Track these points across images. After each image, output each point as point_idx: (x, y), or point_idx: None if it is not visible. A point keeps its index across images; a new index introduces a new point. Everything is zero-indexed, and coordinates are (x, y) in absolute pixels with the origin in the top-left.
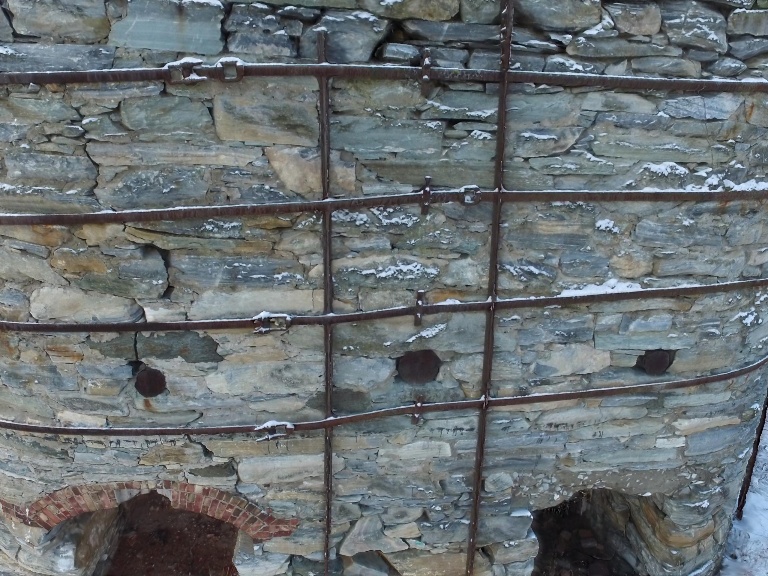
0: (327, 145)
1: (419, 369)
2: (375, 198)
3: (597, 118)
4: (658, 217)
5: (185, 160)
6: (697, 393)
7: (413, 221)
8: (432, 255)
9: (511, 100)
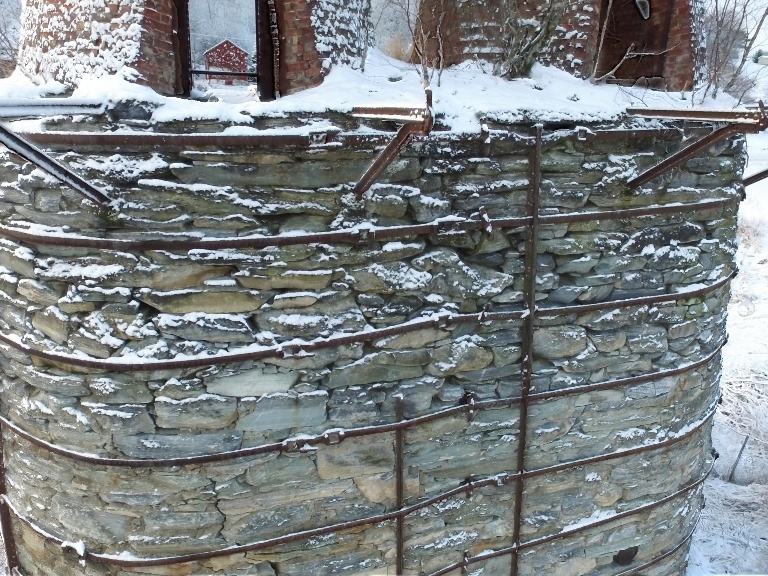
0: None
1: None
2: (436, 498)
3: (585, 409)
4: (627, 465)
5: (295, 500)
6: (653, 568)
7: (460, 504)
8: (474, 523)
9: (528, 410)
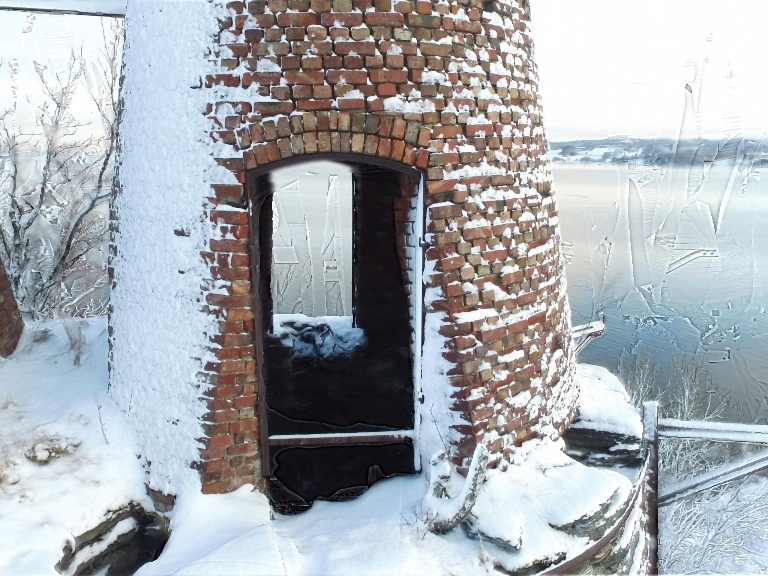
0: None
1: None
2: None
3: None
4: None
5: None
6: None
7: None
8: None
9: None
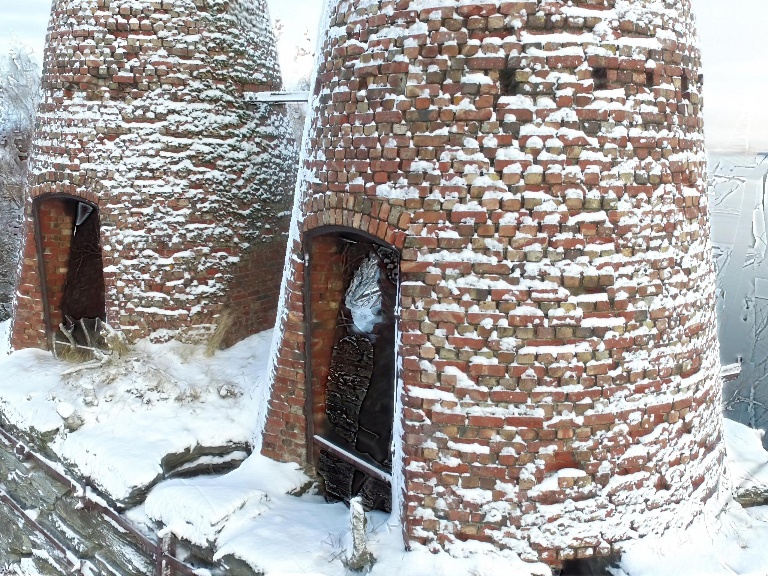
0: None
1: None
2: None
3: None
4: None
5: None
6: None
7: None
8: None
9: None
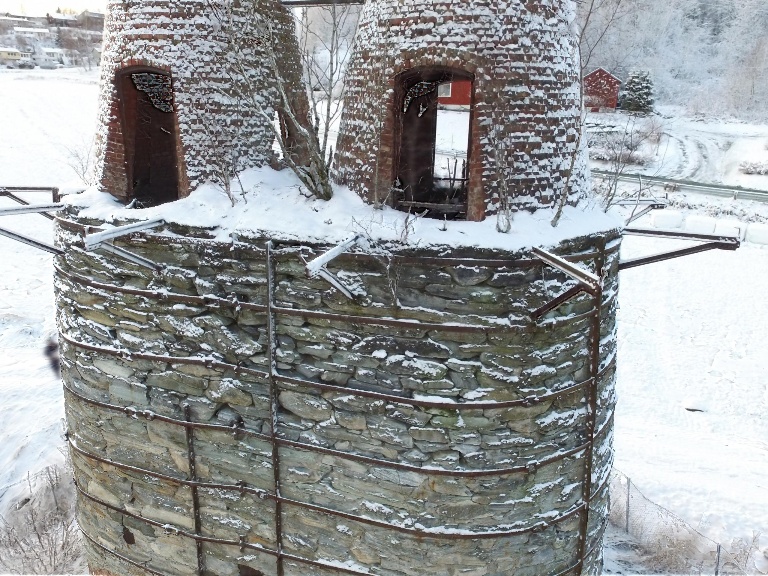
0: (192, 454)
1: (251, 573)
2: (214, 485)
3: (333, 469)
4: (375, 533)
5: (136, 446)
6: None
7: (237, 498)
8: (248, 518)
9: (283, 450)
